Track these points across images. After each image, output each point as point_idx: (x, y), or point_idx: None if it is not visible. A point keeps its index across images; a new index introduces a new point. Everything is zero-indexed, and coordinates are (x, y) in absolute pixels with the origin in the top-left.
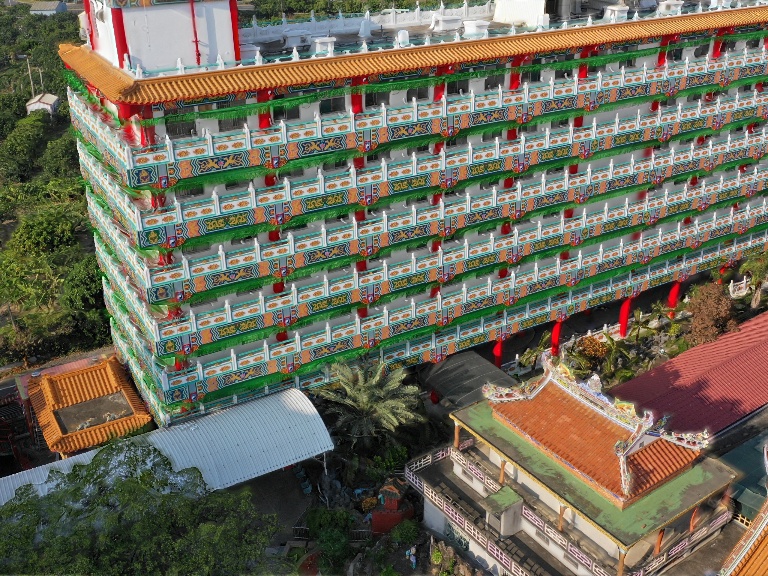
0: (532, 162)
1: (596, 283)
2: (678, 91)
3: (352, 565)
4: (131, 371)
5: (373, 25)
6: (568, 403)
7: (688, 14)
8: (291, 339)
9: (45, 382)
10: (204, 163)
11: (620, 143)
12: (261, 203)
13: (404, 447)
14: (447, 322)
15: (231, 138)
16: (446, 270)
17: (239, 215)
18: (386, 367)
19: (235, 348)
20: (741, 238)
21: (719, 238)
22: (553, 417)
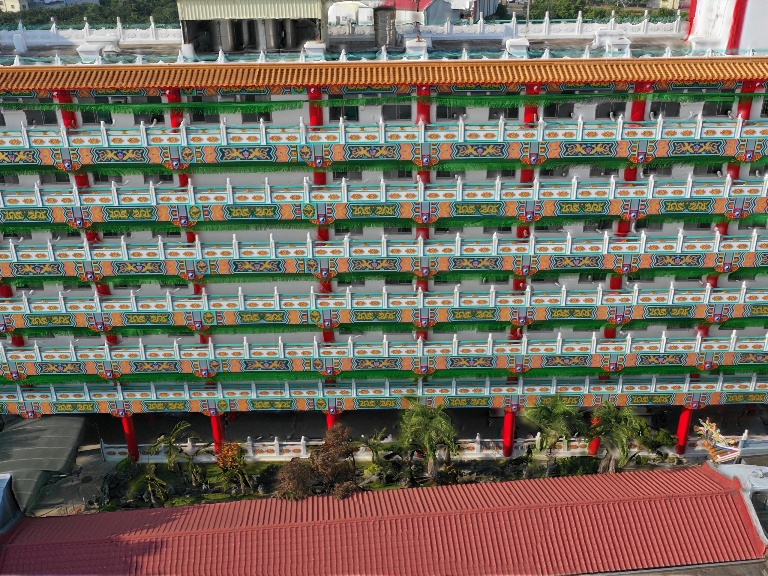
0: (96, 218)
1: (259, 382)
2: (334, 162)
3: None
4: None
5: (63, 40)
6: None
7: (359, 61)
8: None
9: None
10: None
11: (240, 216)
12: None
13: None
14: (19, 377)
15: None
16: (1, 320)
17: None
18: None
19: None
20: (535, 379)
21: (471, 370)
22: None
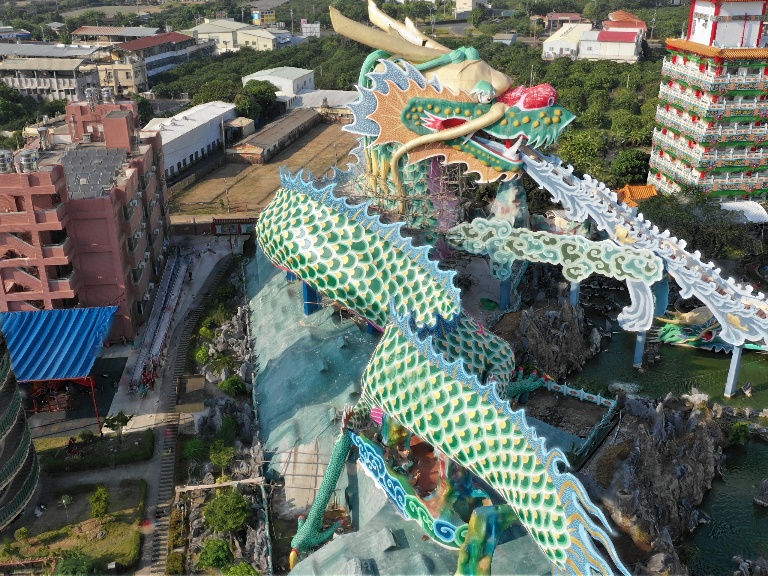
0: None
1: None
2: None
3: None
4: (663, 192)
5: None
6: None
7: None
8: (754, 175)
9: (627, 187)
10: (740, 85)
11: None
12: (758, 107)
13: None
14: None
15: (753, 76)
16: None
17: (748, 110)
18: None
19: (729, 173)
20: None
21: None
22: None
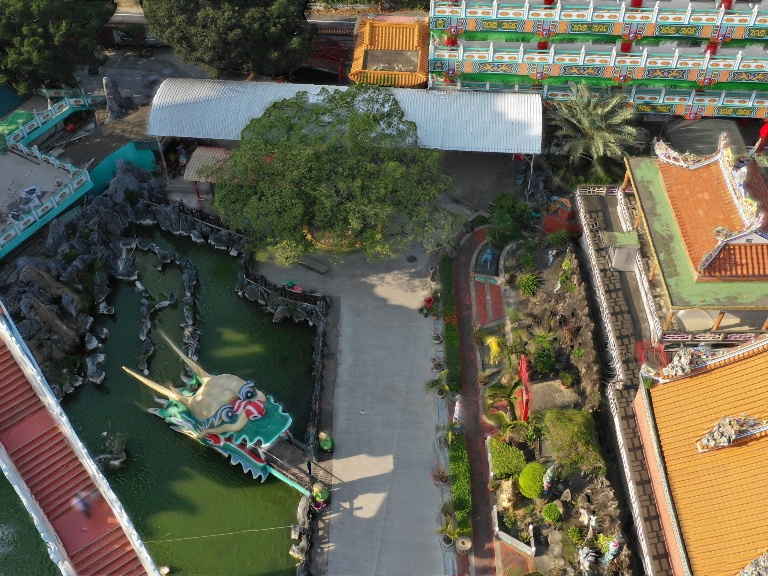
0: None
1: None
2: None
3: (511, 245)
4: None
5: None
6: (718, 184)
7: None
8: (546, 50)
9: (368, 25)
10: None
11: None
12: None
13: (609, 178)
14: (709, 83)
15: None
16: (723, 31)
17: None
18: (634, 106)
19: (495, 42)
20: None
21: None
22: (697, 190)
